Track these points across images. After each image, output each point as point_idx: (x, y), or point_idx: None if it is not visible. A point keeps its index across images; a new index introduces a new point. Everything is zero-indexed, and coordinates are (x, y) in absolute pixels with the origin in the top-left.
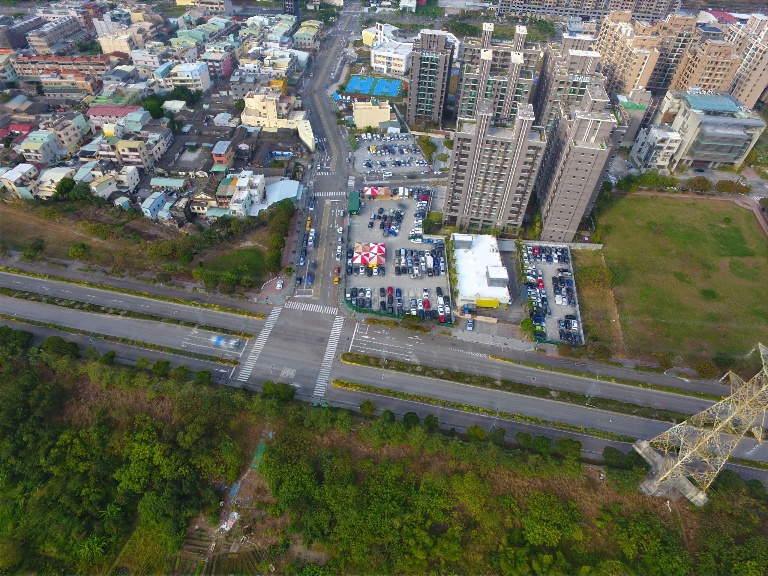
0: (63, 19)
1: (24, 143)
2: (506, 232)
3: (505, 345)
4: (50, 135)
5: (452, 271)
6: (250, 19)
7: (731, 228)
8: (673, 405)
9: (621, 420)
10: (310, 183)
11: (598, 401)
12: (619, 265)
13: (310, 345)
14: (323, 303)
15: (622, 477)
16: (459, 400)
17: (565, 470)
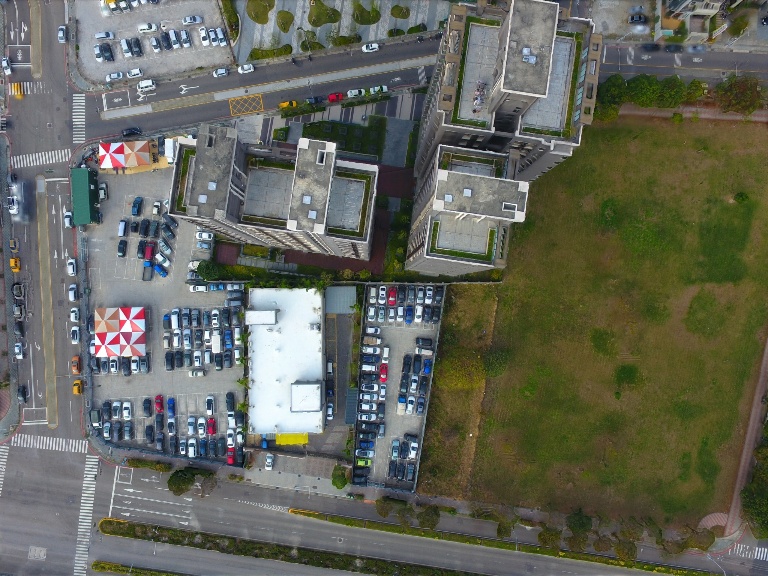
0: None
1: None
2: None
3: (313, 489)
4: None
5: (242, 383)
6: None
7: (741, 207)
8: (497, 566)
9: None
10: None
11: (408, 572)
12: (516, 320)
13: (57, 510)
14: (65, 434)
15: None
16: None
17: None
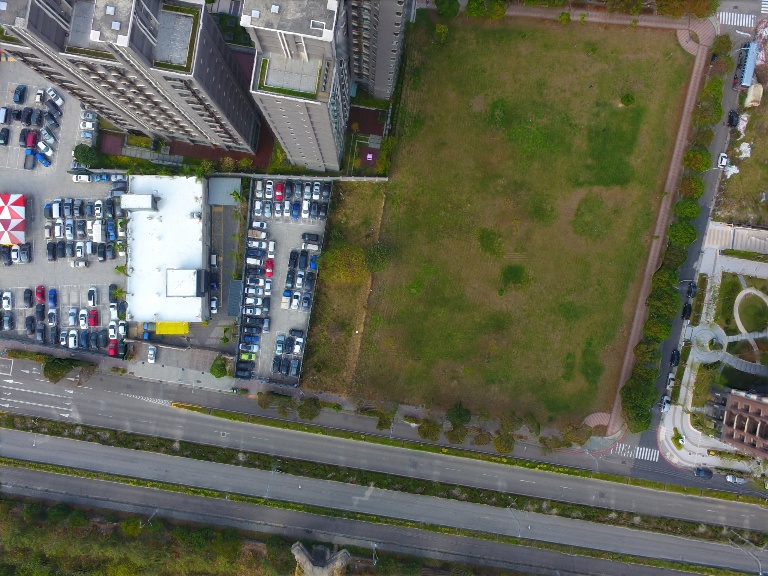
0: None
1: None
2: (236, 148)
3: (197, 383)
4: None
5: (120, 270)
6: None
7: (630, 111)
8: (381, 462)
9: (312, 485)
10: None
11: (290, 466)
12: (403, 218)
13: None
14: None
15: (273, 575)
16: (127, 470)
17: (217, 568)
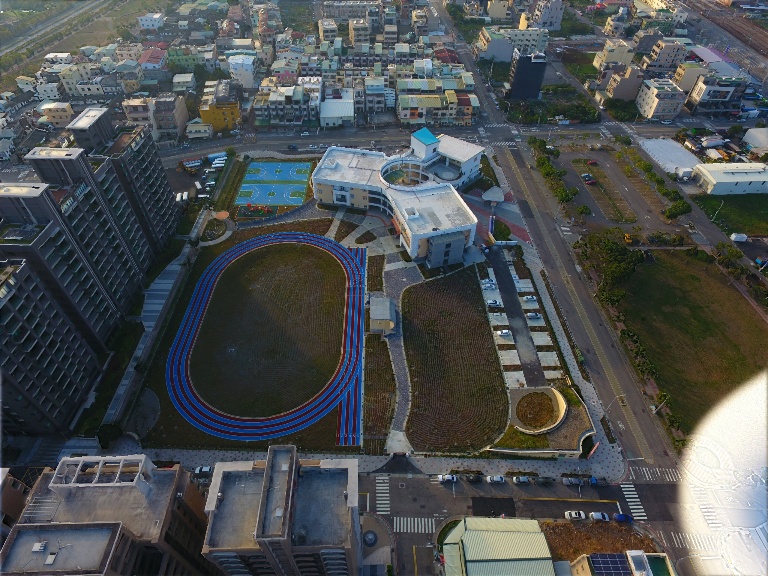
0: (368, 2)
1: (103, 47)
2: None
3: None
4: (110, 50)
5: None
6: (422, 60)
7: None
8: None
9: None
10: (7, 170)
11: None
12: None
13: None
14: None
15: None
16: None
17: None
